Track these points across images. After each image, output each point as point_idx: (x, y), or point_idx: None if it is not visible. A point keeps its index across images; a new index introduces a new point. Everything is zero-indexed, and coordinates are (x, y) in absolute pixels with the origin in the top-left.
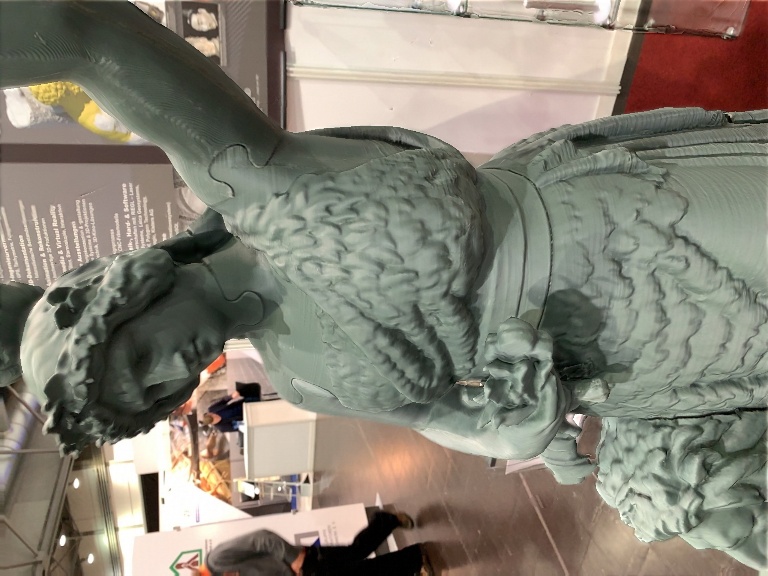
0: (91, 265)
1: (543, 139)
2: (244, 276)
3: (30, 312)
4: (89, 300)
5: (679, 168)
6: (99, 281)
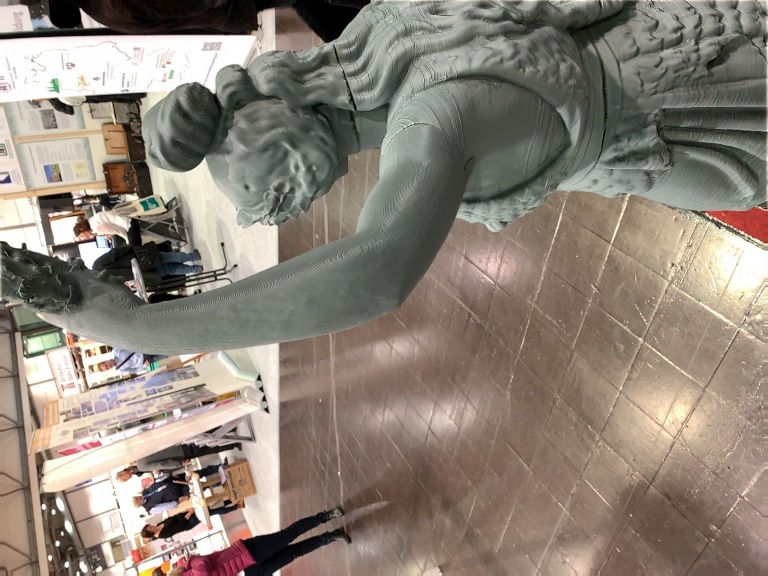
0: (275, 145)
1: (661, 104)
2: (379, 143)
3: (223, 161)
4: (286, 209)
5: (684, 160)
6: (291, 192)
